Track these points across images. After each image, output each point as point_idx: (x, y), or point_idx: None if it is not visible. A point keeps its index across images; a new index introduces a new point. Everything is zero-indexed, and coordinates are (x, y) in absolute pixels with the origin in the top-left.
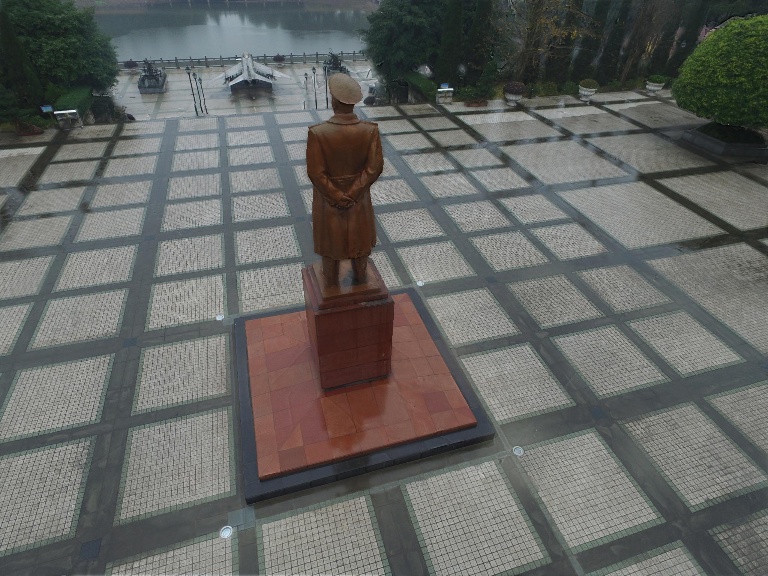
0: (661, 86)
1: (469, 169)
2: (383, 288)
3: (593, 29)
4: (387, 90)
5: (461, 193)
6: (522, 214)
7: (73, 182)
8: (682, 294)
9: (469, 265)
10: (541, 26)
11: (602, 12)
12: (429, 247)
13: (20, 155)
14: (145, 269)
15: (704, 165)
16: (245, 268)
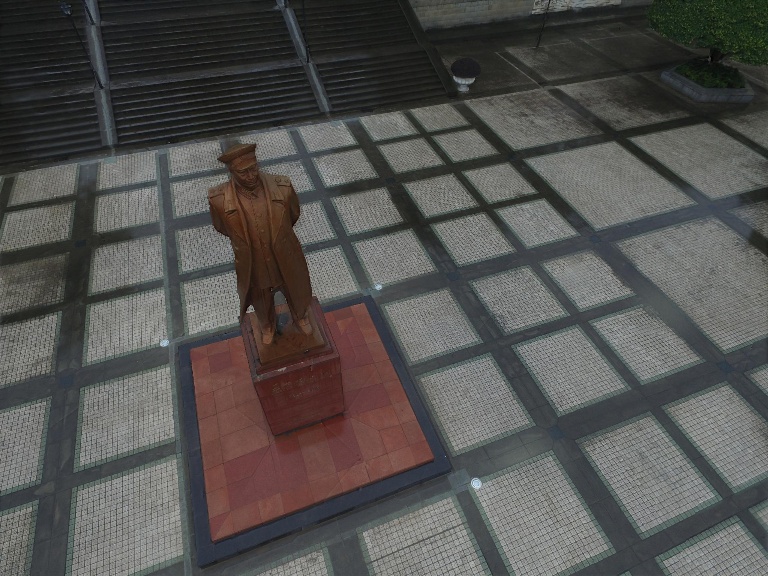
0: None
1: None
2: (247, 321)
3: None
4: None
5: None
6: None
7: None
8: None
9: None
10: None
11: None
12: None
13: None
14: None
15: None
16: None
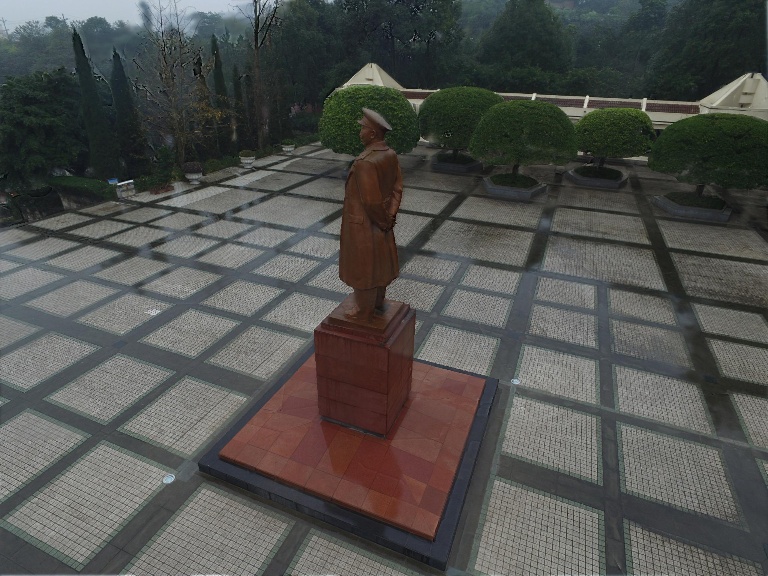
0: (293, 147)
1: (232, 238)
2: None
3: None
4: (14, 207)
5: (252, 257)
6: (317, 253)
7: None
8: (459, 257)
9: (333, 301)
10: None
11: None
12: (286, 304)
13: None
14: None
15: None
16: (123, 420)
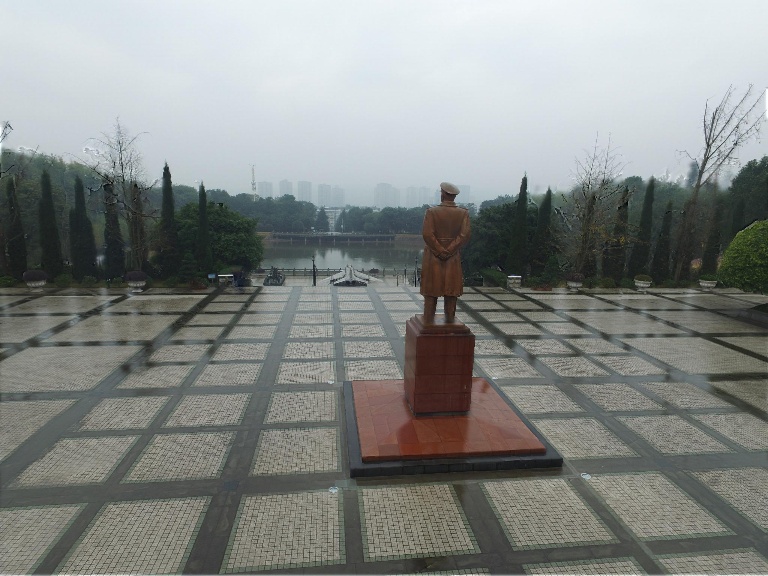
0: (714, 283)
1: (536, 322)
2: None
3: (640, 239)
4: None
5: (530, 334)
6: (585, 348)
7: (226, 312)
8: (745, 403)
9: (538, 372)
10: (592, 232)
11: (646, 228)
12: (502, 360)
13: (191, 298)
14: (276, 355)
15: (763, 332)
16: (351, 360)
